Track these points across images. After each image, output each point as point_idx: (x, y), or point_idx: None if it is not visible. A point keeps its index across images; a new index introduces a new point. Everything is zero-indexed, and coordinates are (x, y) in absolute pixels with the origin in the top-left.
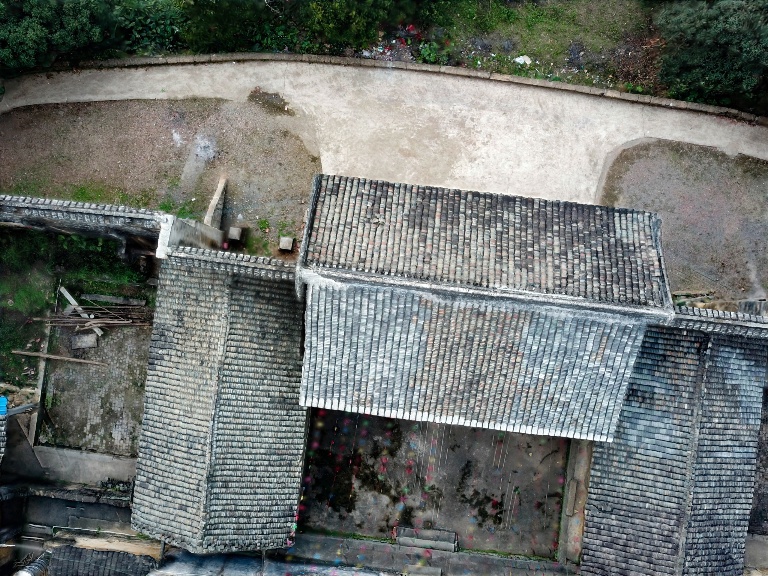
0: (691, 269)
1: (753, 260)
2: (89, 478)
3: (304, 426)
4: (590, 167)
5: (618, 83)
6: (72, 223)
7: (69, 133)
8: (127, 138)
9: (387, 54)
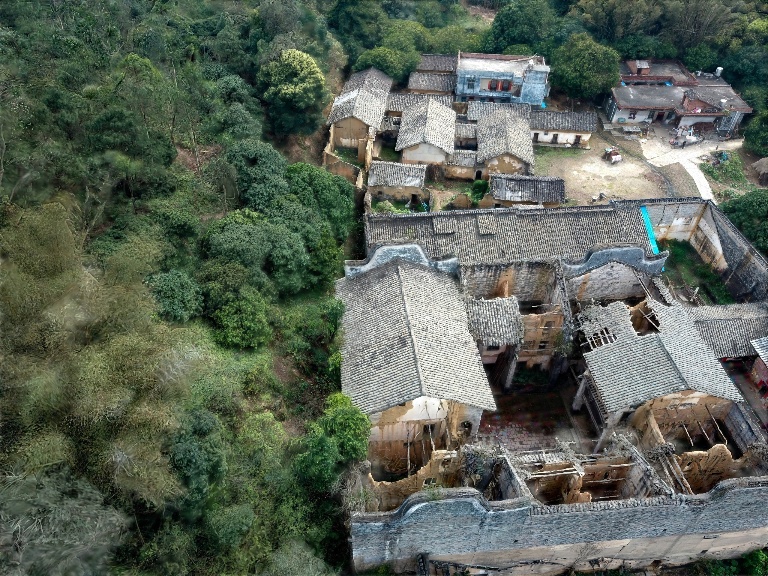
0: None
1: None
2: None
3: (728, 357)
4: None
5: None
6: (749, 273)
7: None
8: None
9: None
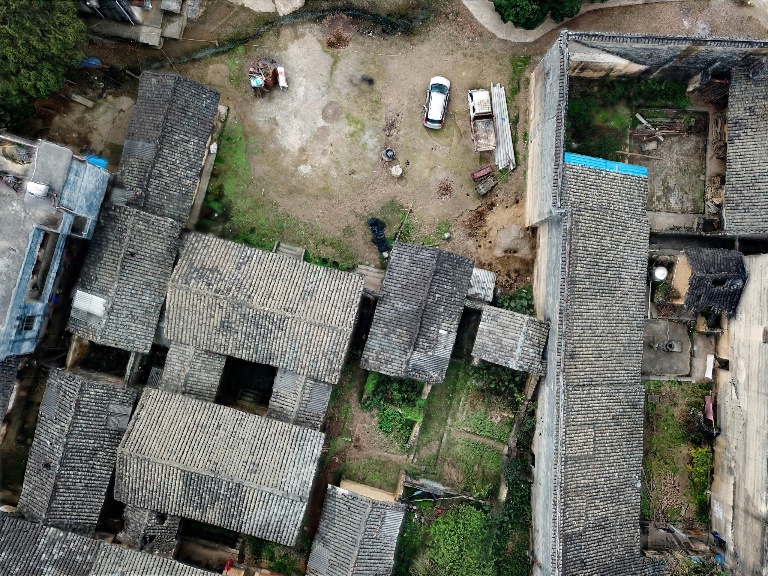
0: None
1: None
2: (661, 226)
3: None
4: None
5: None
6: (698, 58)
7: (622, 24)
8: (657, 25)
9: None
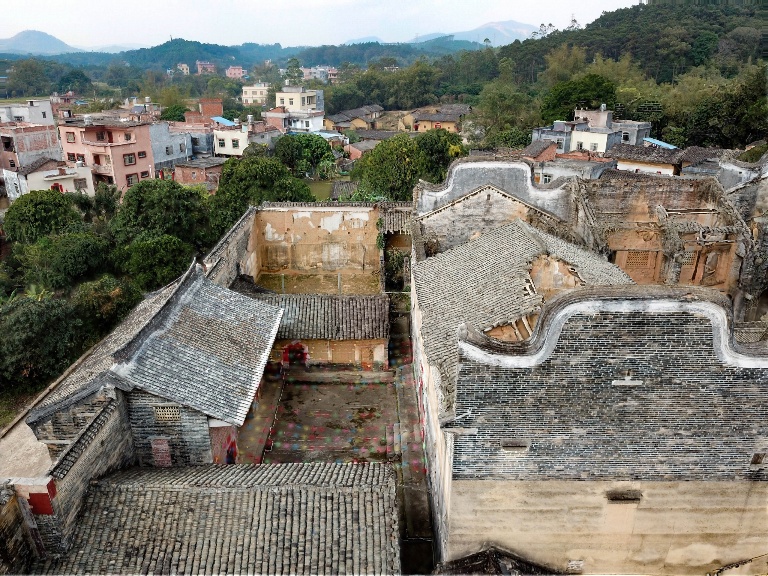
0: None
1: None
2: None
3: None
4: None
5: None
6: None
7: None
8: None
9: None
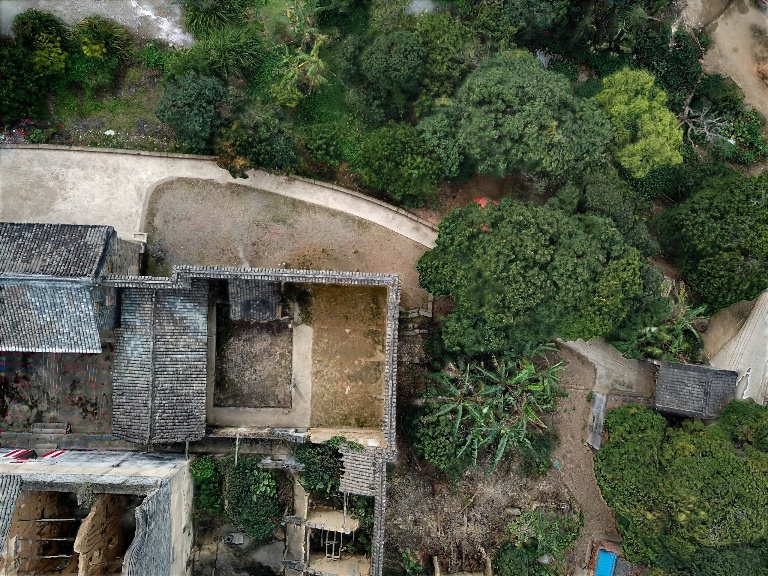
0: (204, 254)
1: (241, 245)
2: None
3: None
4: (138, 198)
5: (170, 142)
6: None
7: None
8: None
9: (7, 140)
